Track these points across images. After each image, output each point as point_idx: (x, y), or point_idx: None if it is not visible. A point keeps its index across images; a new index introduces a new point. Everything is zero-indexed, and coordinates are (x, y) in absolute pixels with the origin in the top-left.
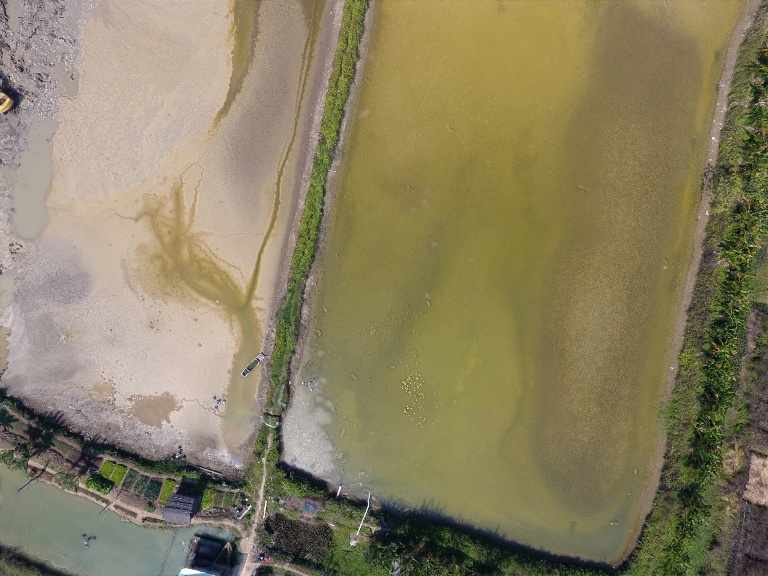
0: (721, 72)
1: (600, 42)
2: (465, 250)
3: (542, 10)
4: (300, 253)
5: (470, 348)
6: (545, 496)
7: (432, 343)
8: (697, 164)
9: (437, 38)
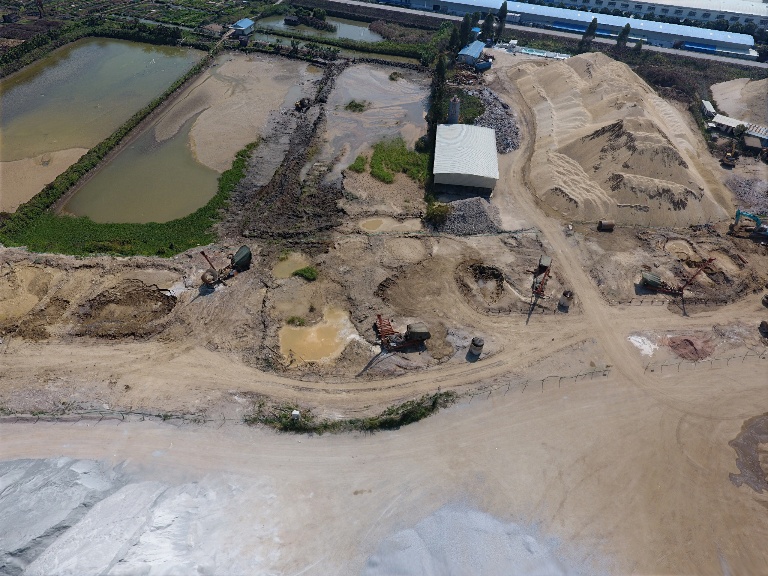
0: None
1: None
2: None
3: None
4: (183, 78)
5: None
6: (112, 46)
7: None
8: None
9: None
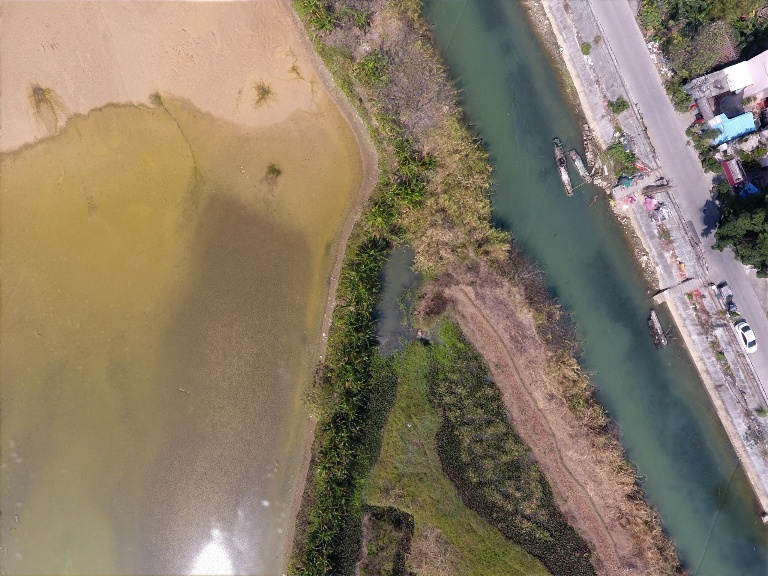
0: (333, 264)
1: (200, 238)
2: (56, 461)
3: (136, 207)
4: None
5: (64, 563)
6: None
7: (22, 559)
8: (309, 361)
9: (22, 241)
